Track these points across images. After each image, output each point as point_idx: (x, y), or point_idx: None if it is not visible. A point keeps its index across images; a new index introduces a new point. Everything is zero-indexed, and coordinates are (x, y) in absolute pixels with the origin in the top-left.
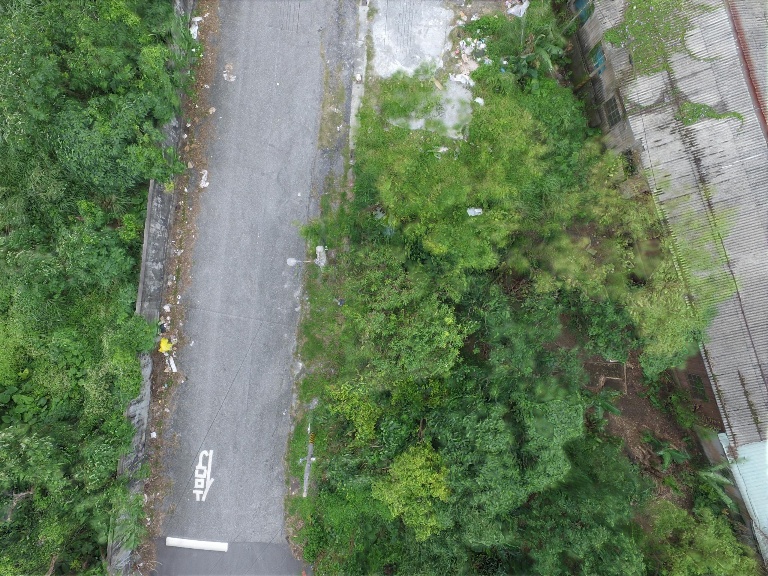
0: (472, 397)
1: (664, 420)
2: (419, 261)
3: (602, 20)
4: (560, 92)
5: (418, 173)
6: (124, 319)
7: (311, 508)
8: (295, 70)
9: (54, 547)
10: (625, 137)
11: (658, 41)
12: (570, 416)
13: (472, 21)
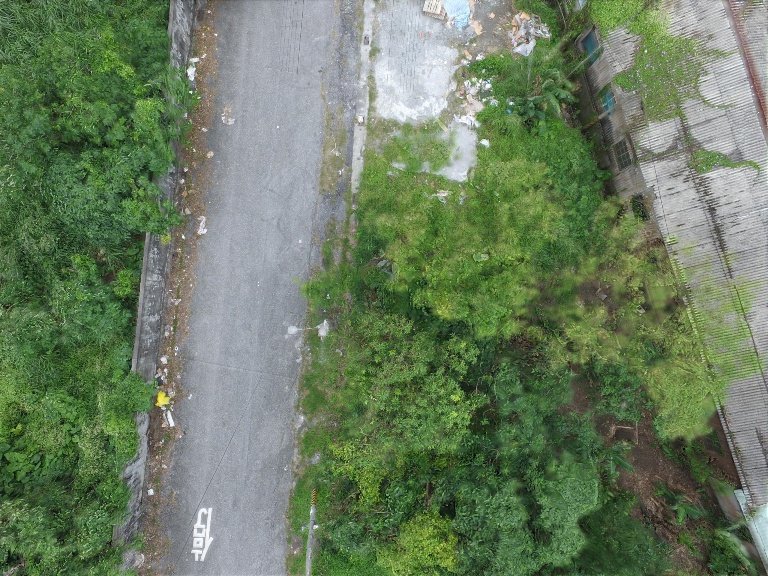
0: (481, 465)
1: (677, 470)
2: (424, 310)
3: (612, 63)
4: (568, 133)
5: (422, 219)
6: (119, 377)
7: (313, 568)
8: (295, 112)
9: None
10: (636, 181)
11: (670, 86)
12: (585, 493)
13: (477, 60)
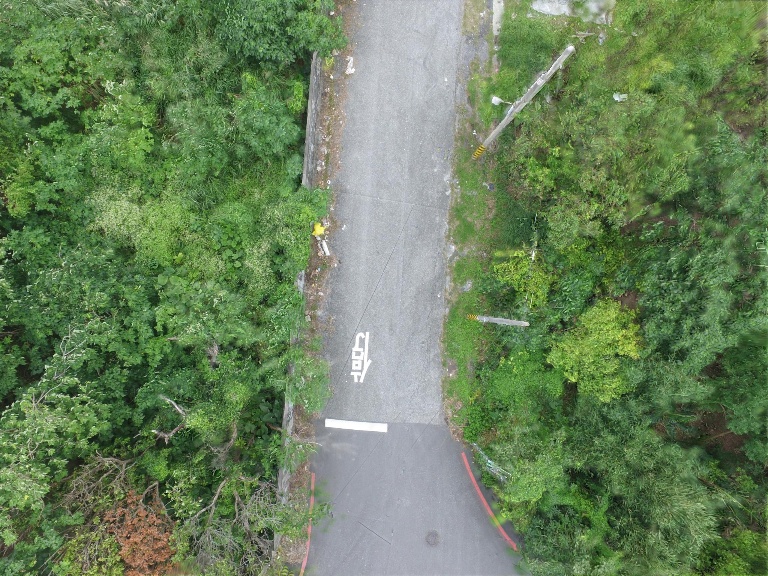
0: (667, 246)
1: None
2: (569, 143)
3: None
4: None
5: None
6: (289, 192)
7: (469, 389)
8: None
9: (237, 410)
10: None
11: None
12: None
13: None
